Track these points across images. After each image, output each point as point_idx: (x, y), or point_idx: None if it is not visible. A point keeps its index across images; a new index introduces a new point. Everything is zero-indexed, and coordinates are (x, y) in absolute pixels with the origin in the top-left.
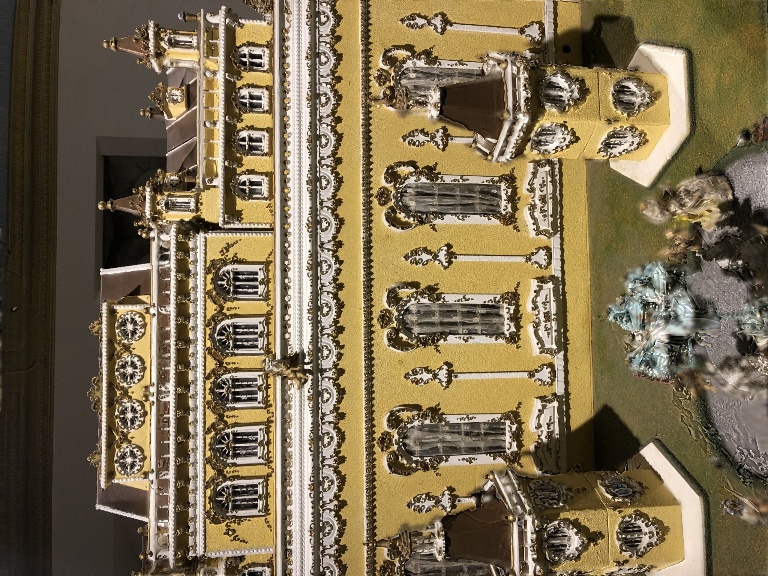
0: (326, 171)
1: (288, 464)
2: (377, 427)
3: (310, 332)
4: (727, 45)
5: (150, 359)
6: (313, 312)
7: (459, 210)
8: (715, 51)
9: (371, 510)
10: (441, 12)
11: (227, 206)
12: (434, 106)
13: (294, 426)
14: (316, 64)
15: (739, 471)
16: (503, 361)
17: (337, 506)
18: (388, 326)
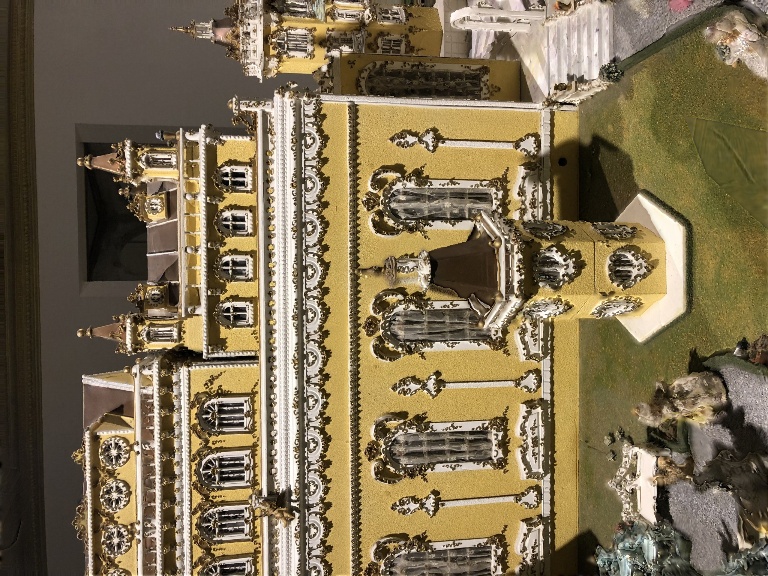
0: (313, 303)
1: None
2: (364, 558)
3: (297, 470)
4: (729, 238)
5: None
6: (300, 450)
7: (449, 336)
8: (716, 238)
9: None
10: (433, 127)
11: (211, 335)
12: (424, 277)
13: (281, 562)
14: (302, 190)
15: None
16: (490, 486)
17: None
18: (375, 458)
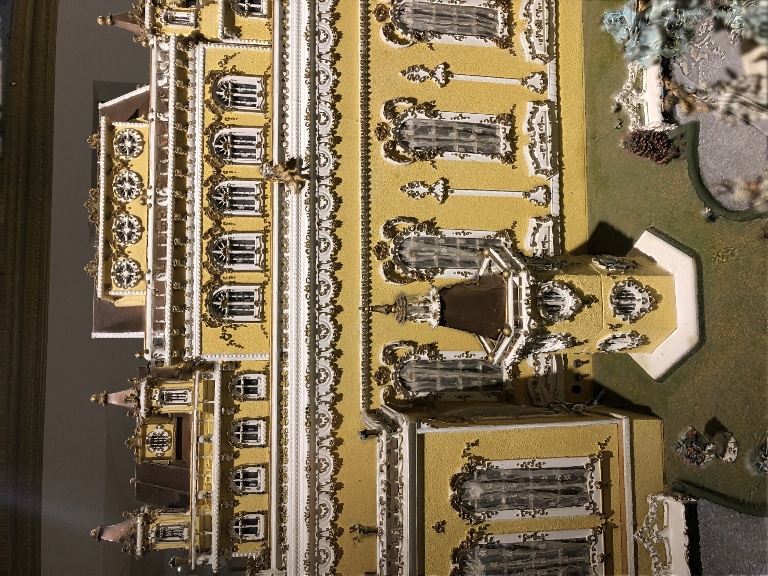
0: None
1: (285, 269)
2: (373, 237)
3: (308, 138)
4: None
5: (148, 176)
6: (311, 119)
7: (456, 31)
8: None
9: (367, 317)
10: None
11: (226, 22)
12: None
13: (291, 230)
14: None
15: (730, 27)
16: (499, 181)
17: (333, 310)
18: (385, 139)
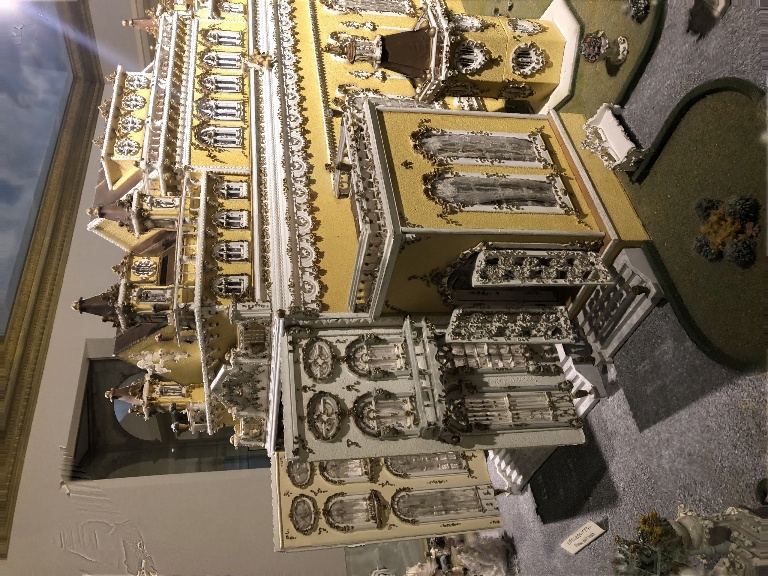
0: None
1: (261, 113)
2: (331, 96)
3: (275, 45)
4: None
5: None
6: None
7: None
8: None
9: (331, 136)
10: None
11: None
12: None
13: None
14: None
15: None
16: None
17: (302, 129)
18: None
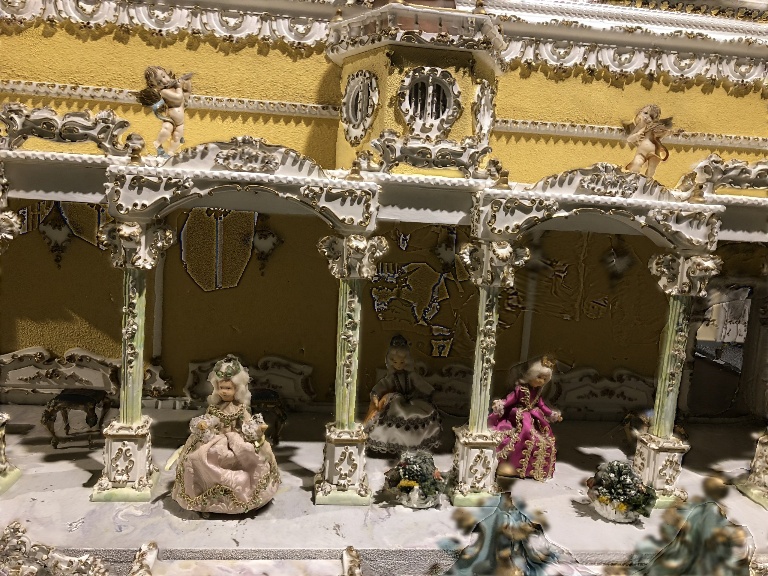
0: None
1: None
2: None
3: None
4: None
5: None
6: None
7: None
8: None
9: None
10: None
11: None
12: None
13: None
14: None
15: None
16: None
17: None
18: None
